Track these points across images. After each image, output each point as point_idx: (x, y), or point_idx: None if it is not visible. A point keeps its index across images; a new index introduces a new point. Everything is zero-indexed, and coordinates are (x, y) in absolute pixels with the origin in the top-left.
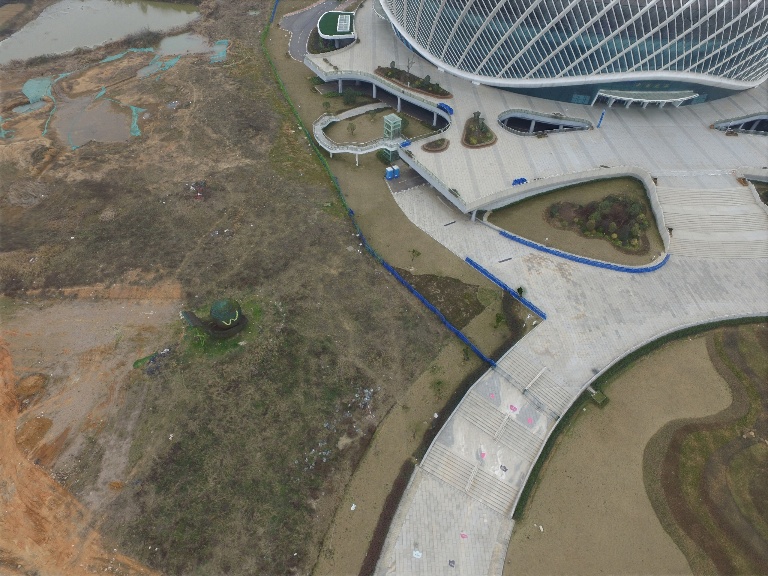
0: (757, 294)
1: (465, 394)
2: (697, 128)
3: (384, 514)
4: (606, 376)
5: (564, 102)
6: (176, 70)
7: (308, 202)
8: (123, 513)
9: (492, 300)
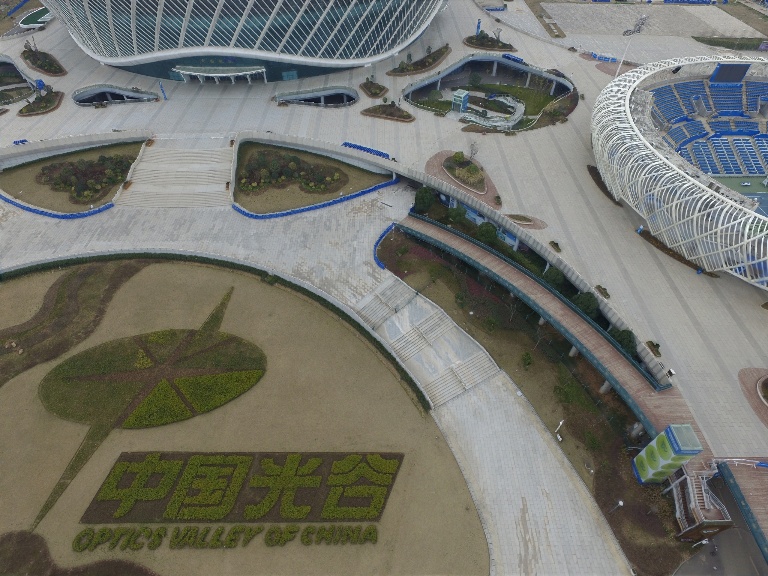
0: (153, 236)
1: None
2: (259, 100)
3: None
4: None
5: (164, 79)
6: None
7: None
8: None
9: None
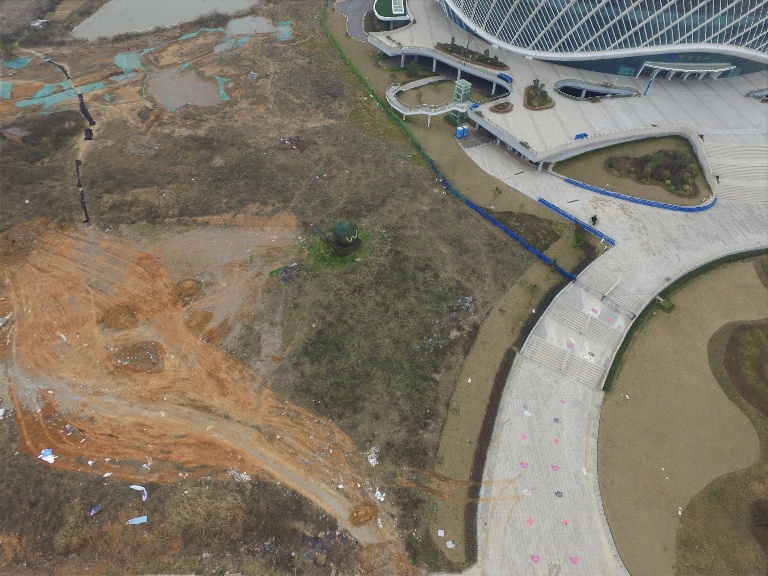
0: None
1: (552, 300)
2: (734, 96)
3: (497, 385)
4: (671, 288)
5: (611, 74)
6: (250, 46)
7: (392, 154)
8: (287, 377)
9: (566, 231)
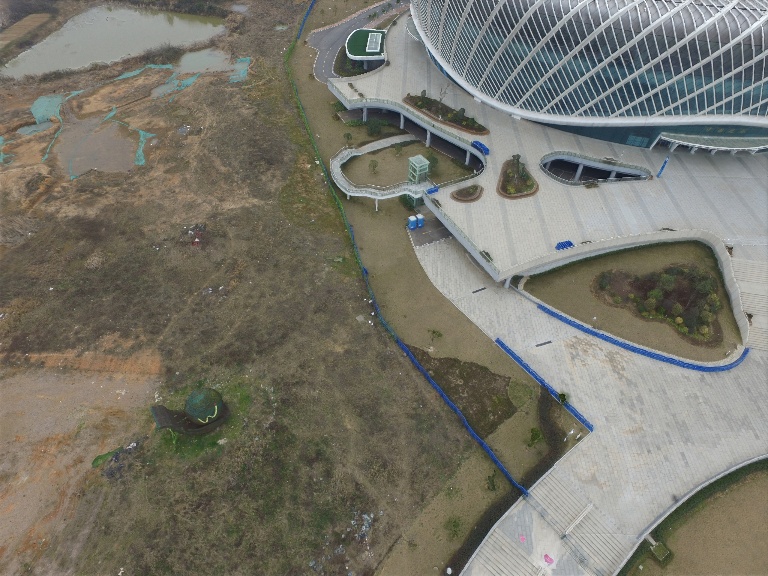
0: None
1: (488, 533)
2: None
3: None
4: (670, 521)
5: (618, 143)
6: (192, 90)
7: (317, 256)
8: None
9: (526, 399)
